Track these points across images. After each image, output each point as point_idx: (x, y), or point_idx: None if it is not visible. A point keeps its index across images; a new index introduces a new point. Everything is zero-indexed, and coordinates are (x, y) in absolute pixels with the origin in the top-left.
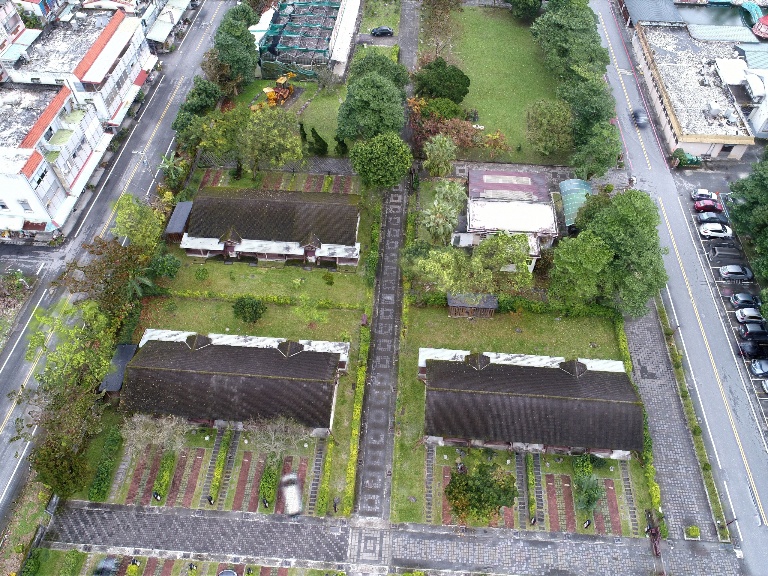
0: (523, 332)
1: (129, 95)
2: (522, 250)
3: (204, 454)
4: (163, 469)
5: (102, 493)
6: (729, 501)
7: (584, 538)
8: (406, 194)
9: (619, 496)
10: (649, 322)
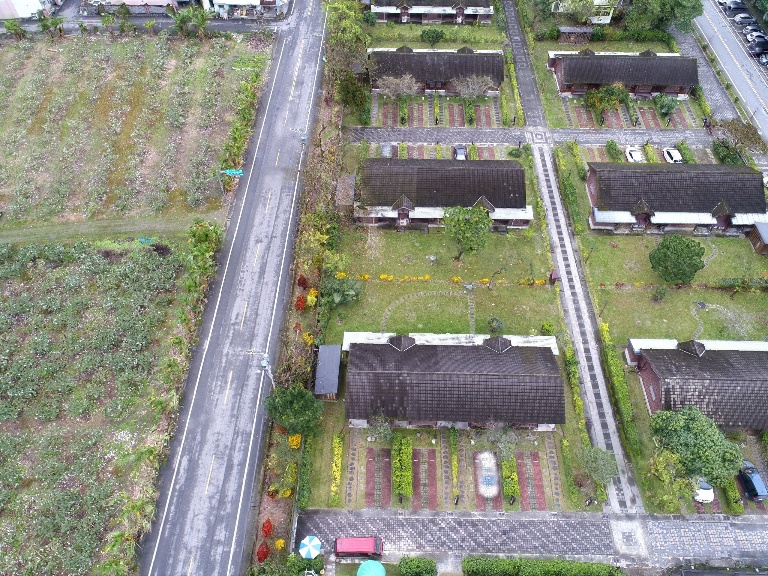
0: (610, 50)
1: None
2: None
3: (423, 105)
4: (403, 108)
5: (369, 119)
6: (751, 114)
7: (667, 130)
8: None
9: (685, 114)
10: (691, 44)
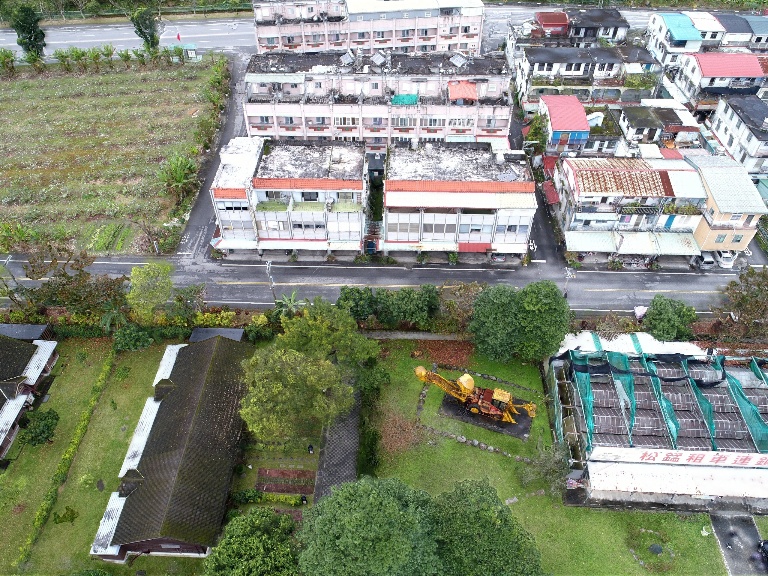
0: None
1: (435, 244)
2: None
3: None
4: None
5: None
6: None
7: None
8: None
9: None
10: None
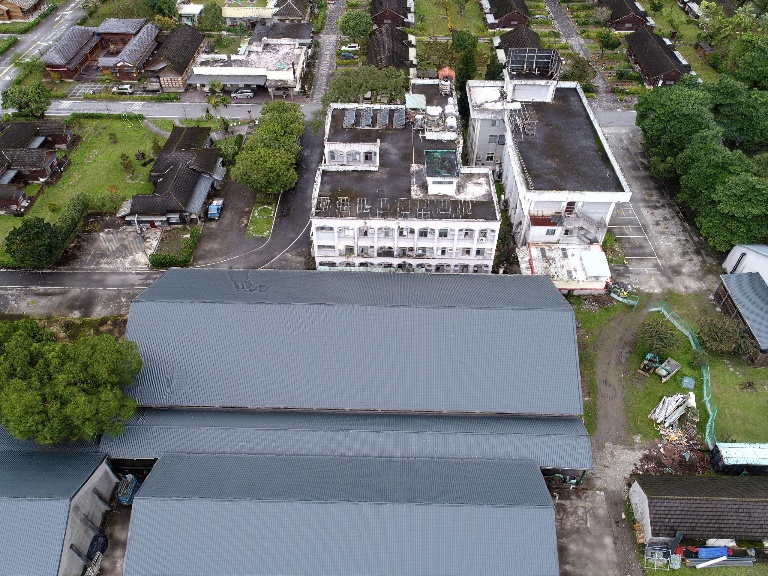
0: None
1: None
2: (739, 24)
3: None
4: (578, 5)
5: None
6: None
7: None
8: None
9: None
10: None
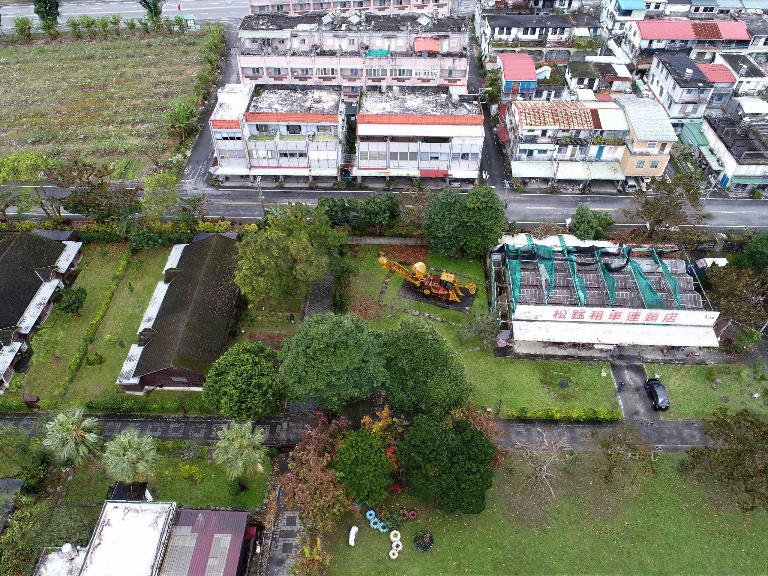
0: None
1: (401, 171)
2: None
3: None
4: None
5: None
6: None
7: None
8: None
9: None
10: None
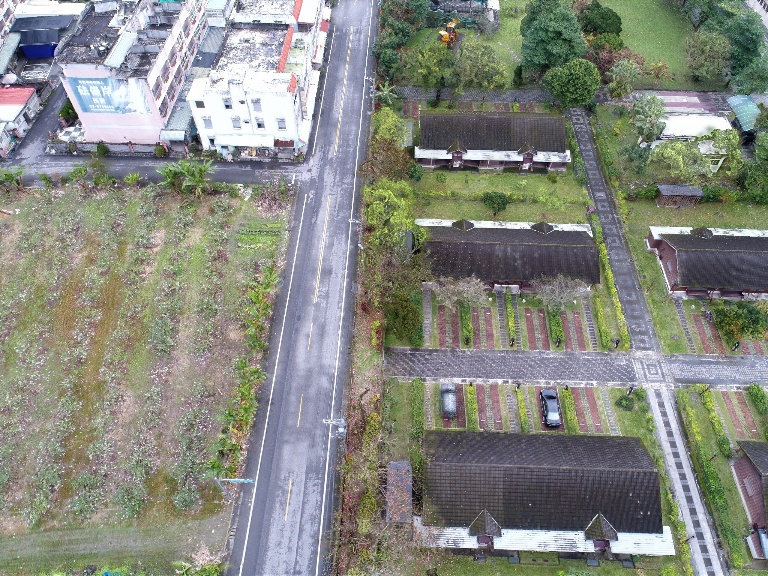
0: (724, 216)
1: (320, 39)
2: None
3: (491, 311)
4: (466, 320)
5: (422, 339)
6: None
7: None
8: (585, 116)
9: None
10: None
